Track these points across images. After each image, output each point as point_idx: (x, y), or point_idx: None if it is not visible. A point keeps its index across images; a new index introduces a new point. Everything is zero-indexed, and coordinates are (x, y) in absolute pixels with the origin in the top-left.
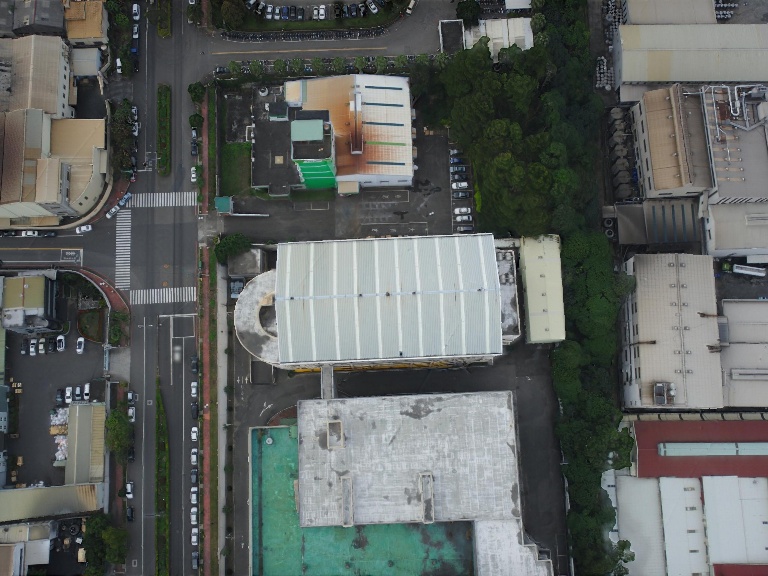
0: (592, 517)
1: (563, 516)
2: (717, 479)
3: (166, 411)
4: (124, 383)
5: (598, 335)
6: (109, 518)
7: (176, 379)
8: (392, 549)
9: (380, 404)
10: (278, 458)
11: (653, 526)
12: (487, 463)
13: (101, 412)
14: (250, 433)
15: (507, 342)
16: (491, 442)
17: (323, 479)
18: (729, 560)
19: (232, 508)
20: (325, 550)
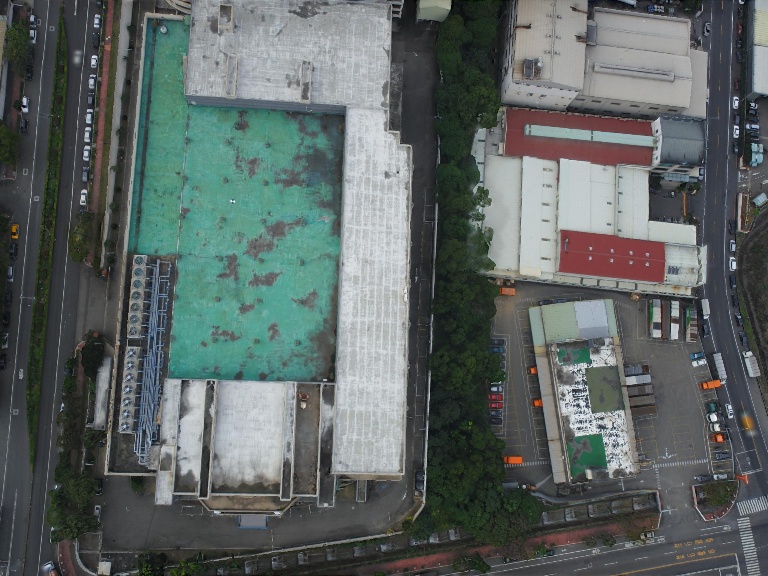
0: (458, 168)
1: (433, 172)
2: (572, 162)
3: (68, 38)
4: (27, 7)
5: (481, 15)
6: (3, 122)
7: (80, 10)
8: (270, 133)
9: (271, 2)
10: (171, 47)
11: (513, 198)
12: (363, 62)
13: (2, 26)
14: (146, 18)
15: (398, 8)
16: (369, 45)
17: (211, 58)
18: (574, 229)
19: (126, 134)
20: (208, 128)
